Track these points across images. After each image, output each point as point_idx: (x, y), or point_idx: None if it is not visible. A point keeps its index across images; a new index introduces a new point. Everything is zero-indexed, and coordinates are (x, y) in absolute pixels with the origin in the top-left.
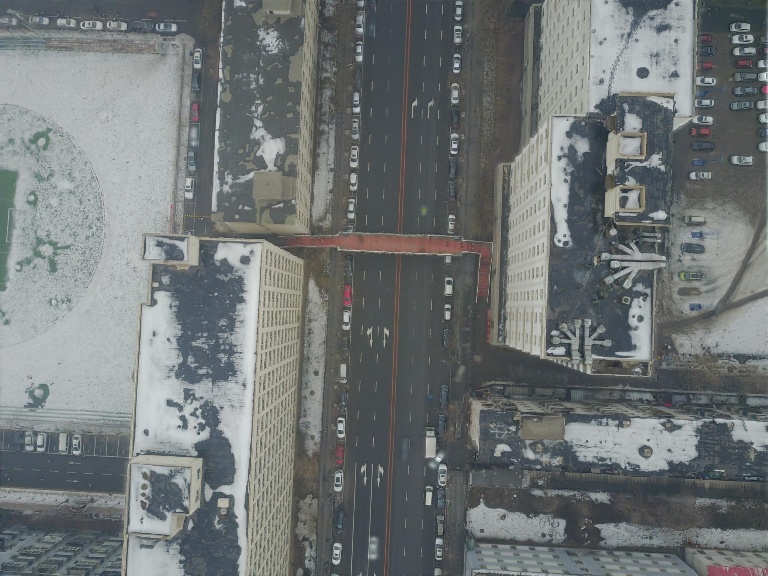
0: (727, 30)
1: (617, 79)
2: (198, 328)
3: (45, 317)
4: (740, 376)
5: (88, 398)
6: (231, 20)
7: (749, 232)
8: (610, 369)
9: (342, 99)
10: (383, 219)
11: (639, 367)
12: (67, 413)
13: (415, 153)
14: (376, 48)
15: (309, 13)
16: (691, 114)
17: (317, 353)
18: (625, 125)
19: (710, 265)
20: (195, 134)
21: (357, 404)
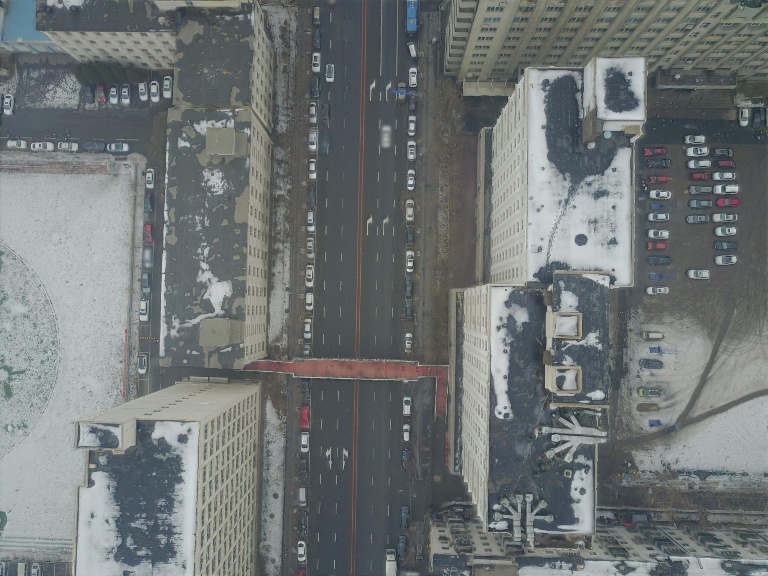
0: (682, 142)
1: (555, 247)
2: (137, 509)
3: (1, 443)
4: (701, 492)
5: (46, 526)
6: (175, 161)
7: (707, 346)
8: (553, 542)
9: (296, 217)
10: (340, 338)
11: (582, 540)
12: (25, 541)
13: (371, 271)
14: (330, 164)
15: (257, 143)
16: (630, 282)
17: (276, 475)
18: (561, 303)
19: (669, 380)
20: (149, 256)
21: (317, 526)
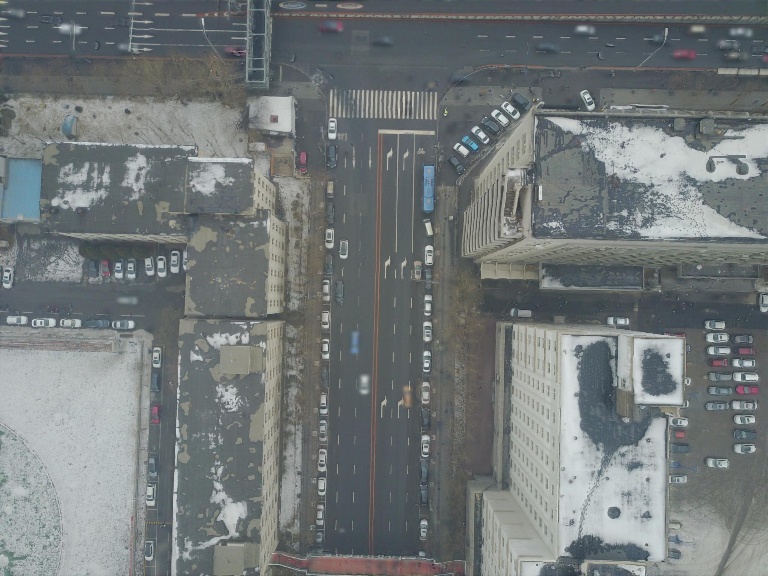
0: (702, 326)
1: (588, 520)
2: None
3: None
4: None
5: None
6: (188, 375)
7: (725, 535)
8: None
9: (309, 399)
10: (353, 524)
11: None
12: None
13: (385, 454)
14: (343, 344)
15: (271, 342)
16: (664, 558)
17: None
18: None
19: (686, 569)
20: (156, 439)
21: None
